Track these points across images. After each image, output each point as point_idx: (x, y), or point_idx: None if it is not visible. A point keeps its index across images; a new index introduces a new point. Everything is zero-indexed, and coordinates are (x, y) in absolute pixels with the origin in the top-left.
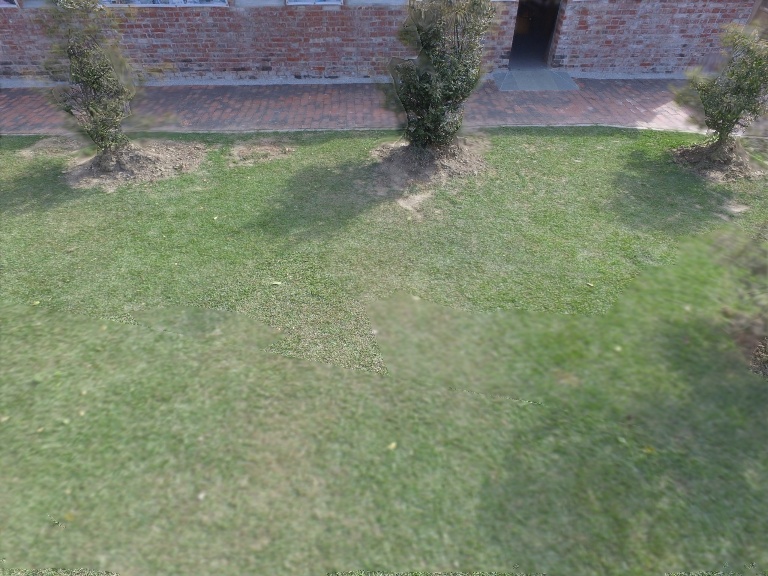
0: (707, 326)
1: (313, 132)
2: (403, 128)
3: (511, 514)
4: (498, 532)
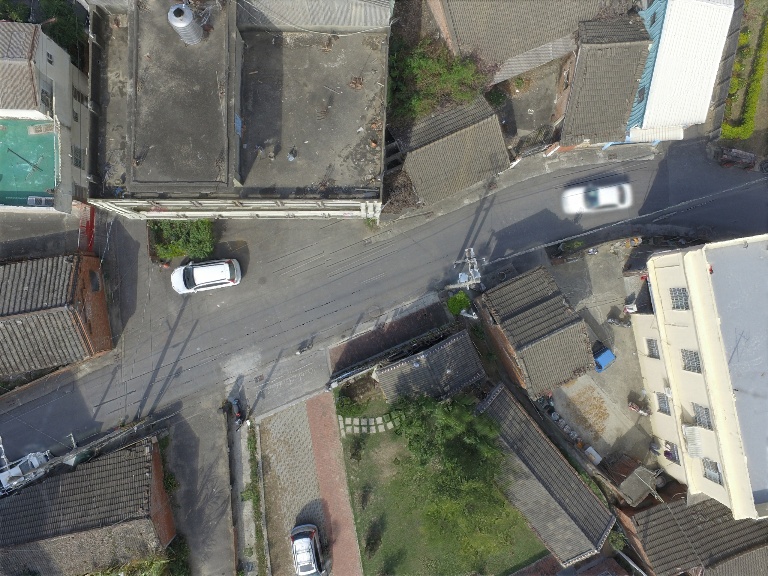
0: None
1: None
2: None
3: (406, 551)
4: (406, 550)
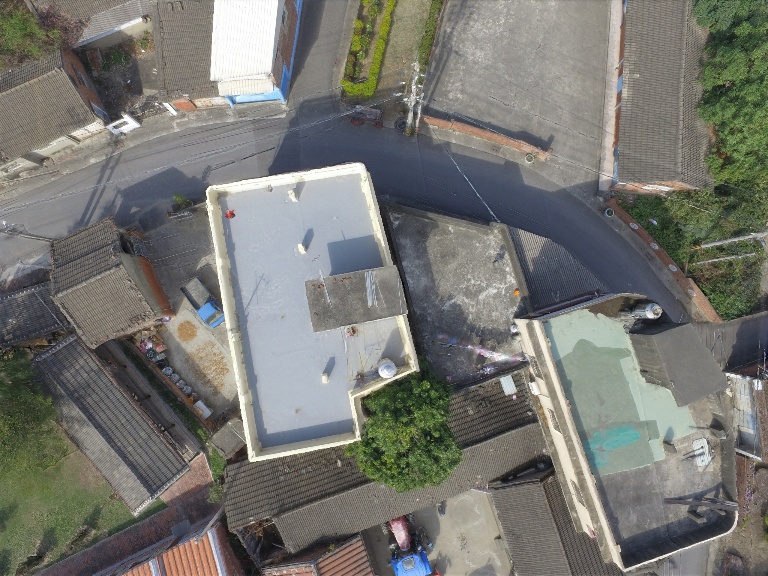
0: (2, 532)
1: (64, 559)
2: (49, 568)
3: (17, 505)
4: (17, 504)
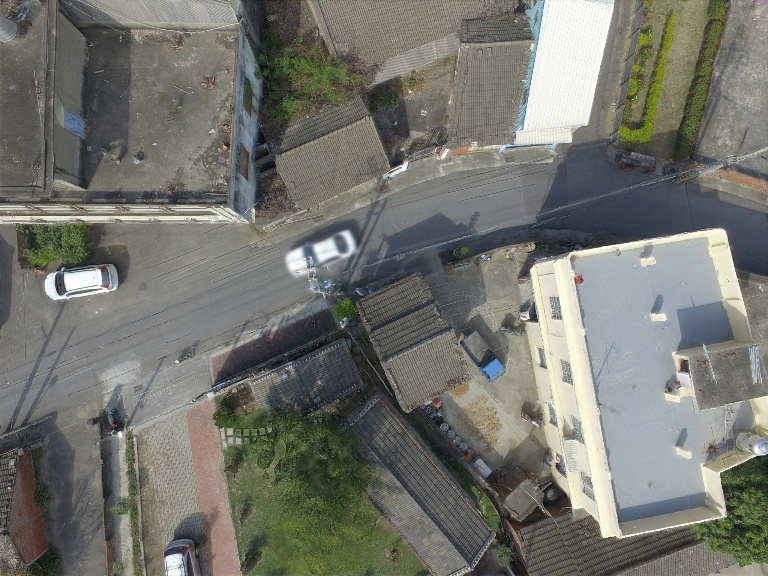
0: None
1: None
2: None
3: (289, 566)
4: (289, 565)
